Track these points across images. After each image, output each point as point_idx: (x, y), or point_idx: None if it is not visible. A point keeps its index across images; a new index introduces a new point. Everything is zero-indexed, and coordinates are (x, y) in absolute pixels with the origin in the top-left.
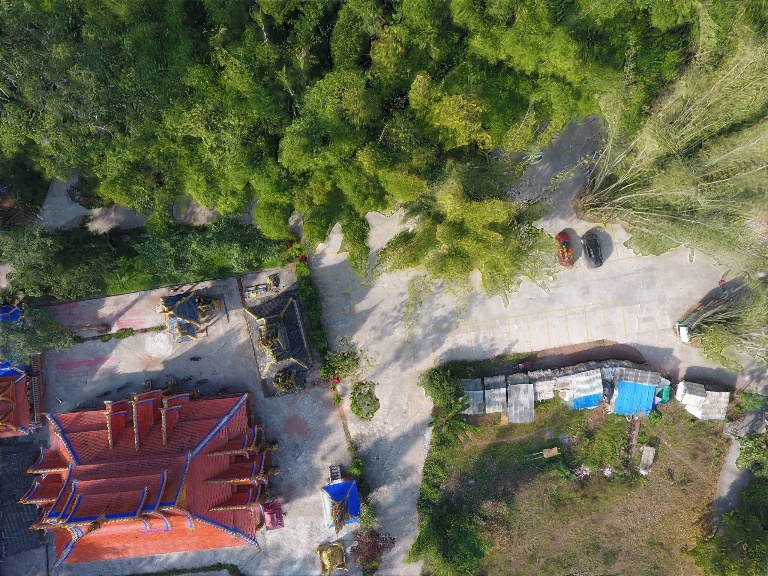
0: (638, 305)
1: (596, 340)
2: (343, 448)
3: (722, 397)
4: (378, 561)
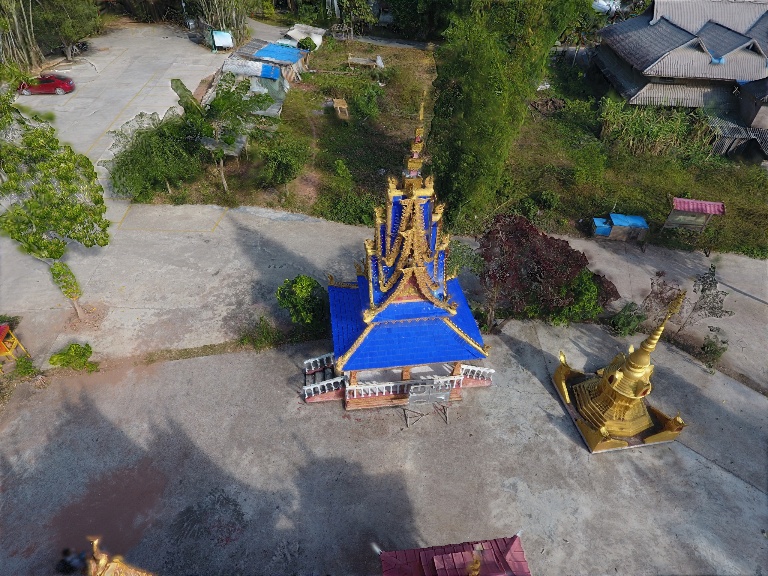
0: (174, 64)
1: (199, 83)
2: (252, 363)
3: (300, 26)
4: (563, 241)
